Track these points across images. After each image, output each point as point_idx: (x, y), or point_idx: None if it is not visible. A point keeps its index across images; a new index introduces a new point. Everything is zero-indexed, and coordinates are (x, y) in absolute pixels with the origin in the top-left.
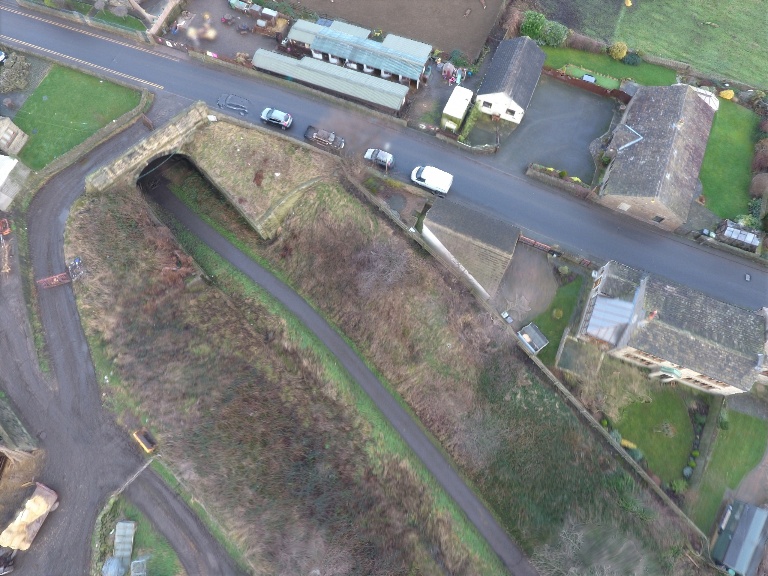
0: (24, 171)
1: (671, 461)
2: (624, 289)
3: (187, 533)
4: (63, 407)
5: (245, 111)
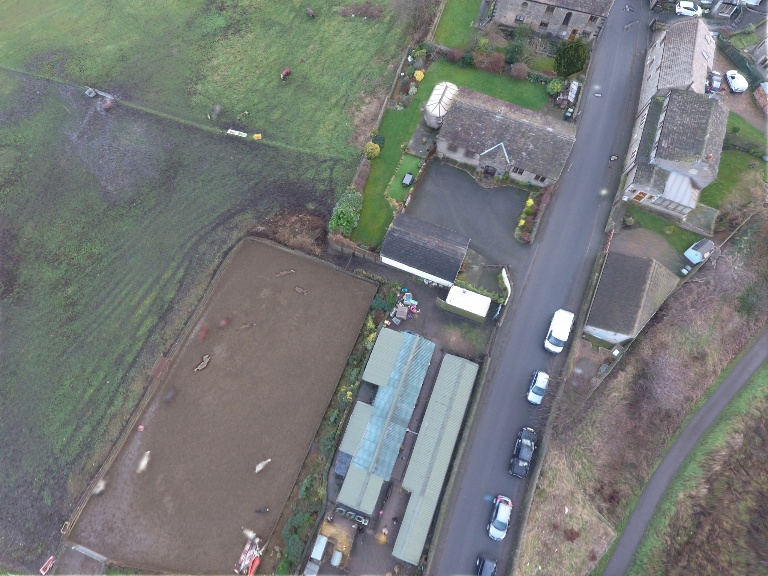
0: None
1: (761, 167)
2: (660, 176)
3: None
4: None
5: None
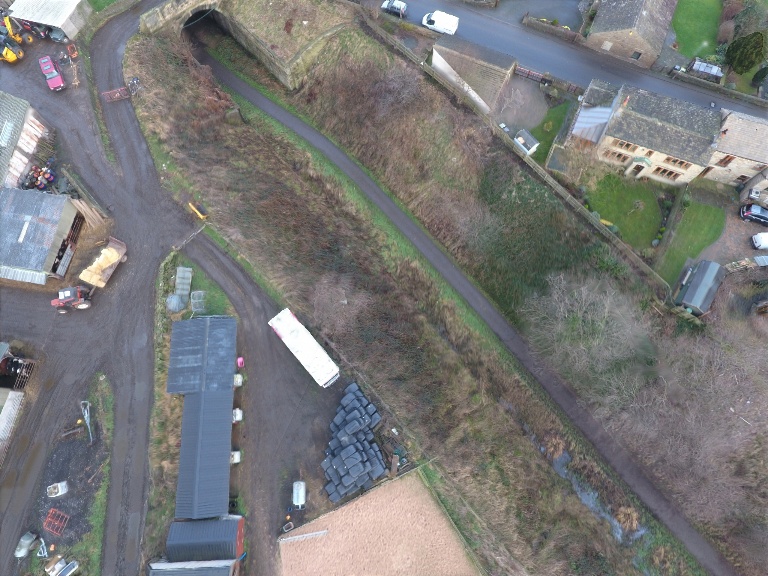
0: (88, 8)
1: (642, 236)
2: (604, 98)
3: (235, 281)
4: (128, 188)
5: None
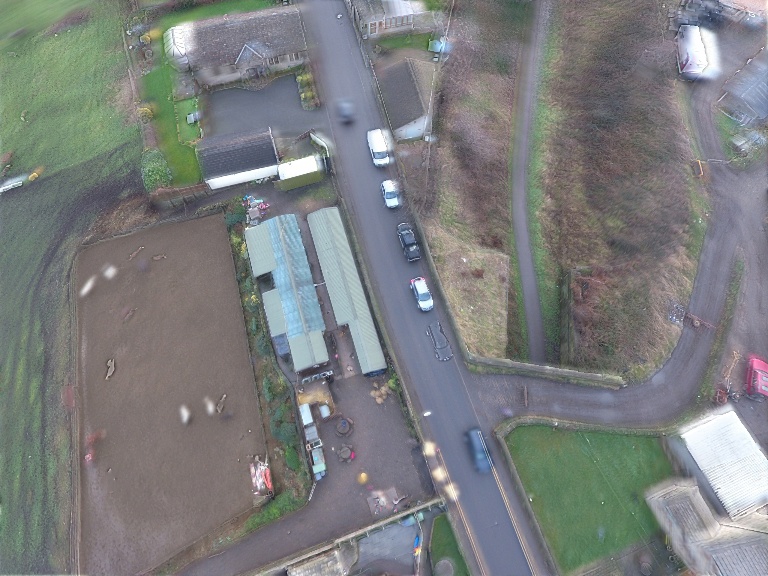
0: None
1: None
2: (375, 4)
3: (699, 121)
4: (739, 233)
5: None
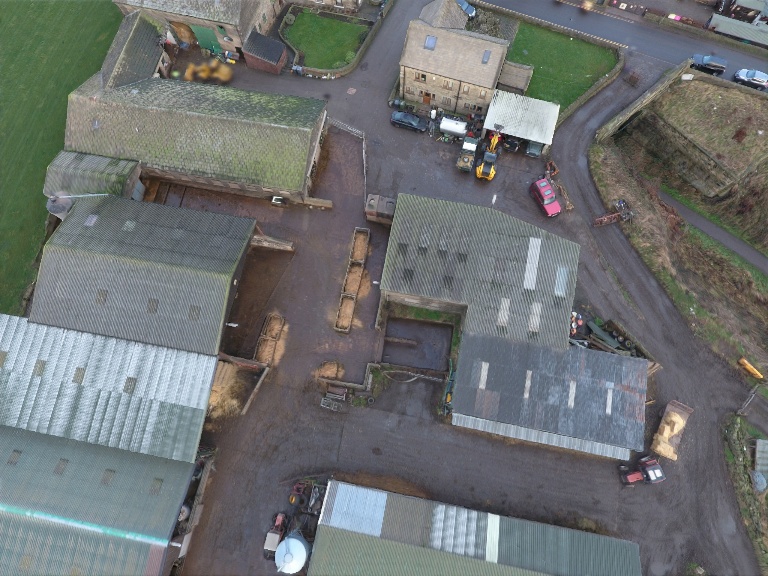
0: None
1: None
2: None
3: None
4: (655, 335)
5: (722, 71)
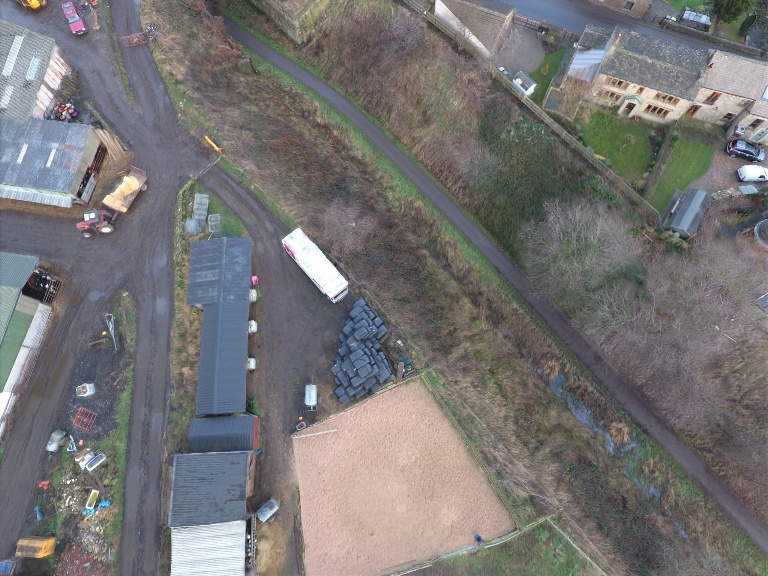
0: None
1: (633, 169)
2: (598, 41)
3: (249, 208)
4: (147, 124)
5: None
